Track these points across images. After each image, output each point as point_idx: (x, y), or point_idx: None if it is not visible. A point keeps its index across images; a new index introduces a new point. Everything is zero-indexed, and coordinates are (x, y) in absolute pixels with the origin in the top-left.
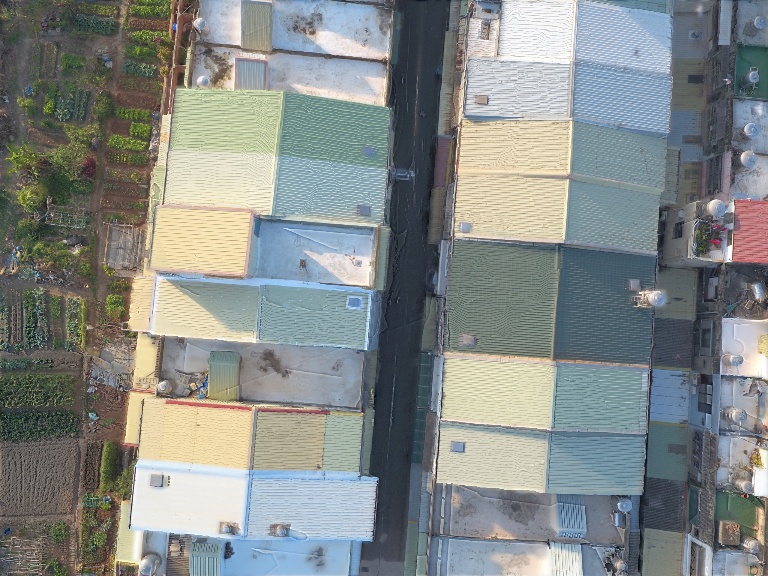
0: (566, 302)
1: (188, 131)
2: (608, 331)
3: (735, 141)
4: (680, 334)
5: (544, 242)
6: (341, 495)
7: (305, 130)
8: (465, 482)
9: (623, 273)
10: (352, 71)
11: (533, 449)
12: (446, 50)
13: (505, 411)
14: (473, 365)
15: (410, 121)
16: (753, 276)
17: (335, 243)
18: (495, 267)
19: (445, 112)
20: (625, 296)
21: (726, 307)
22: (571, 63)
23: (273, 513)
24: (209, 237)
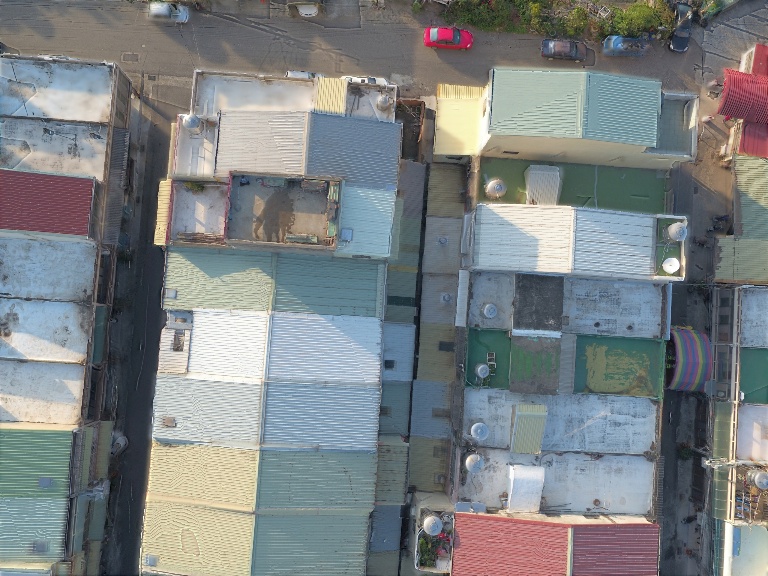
0: None
1: None
2: None
3: None
4: None
5: None
6: None
7: None
8: None
9: None
10: (51, 374)
11: None
12: None
13: None
14: None
15: (141, 398)
16: None
17: None
18: None
19: None
20: None
21: None
22: (262, 384)
23: None
24: None
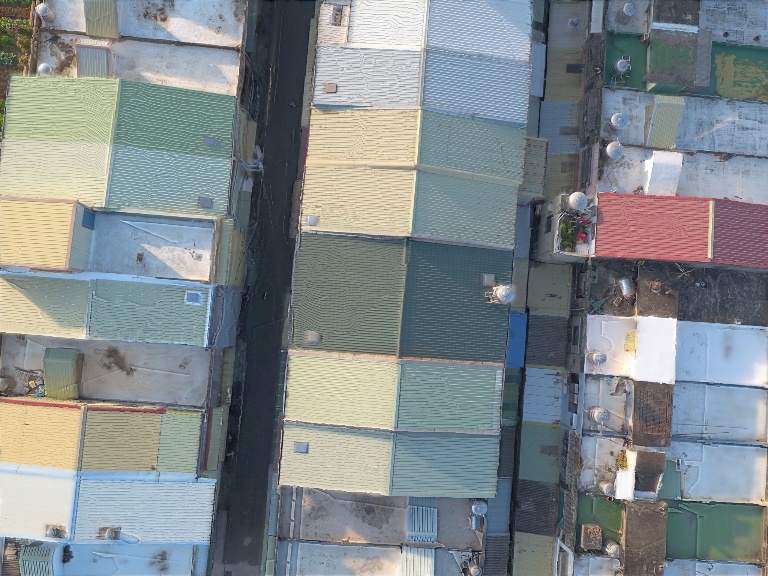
0: (414, 298)
1: (15, 119)
2: (457, 328)
3: (605, 132)
4: (554, 331)
5: (391, 235)
6: (177, 497)
7: (142, 119)
8: (308, 484)
9: (477, 268)
10: (205, 59)
11: (377, 450)
12: (311, 38)
13: (348, 410)
14: (316, 363)
15: (278, 111)
16: (622, 271)
17: (174, 236)
18: (349, 261)
19: (308, 102)
20: (479, 292)
21: (593, 303)
22: (422, 50)
23: (102, 516)
24: (32, 229)
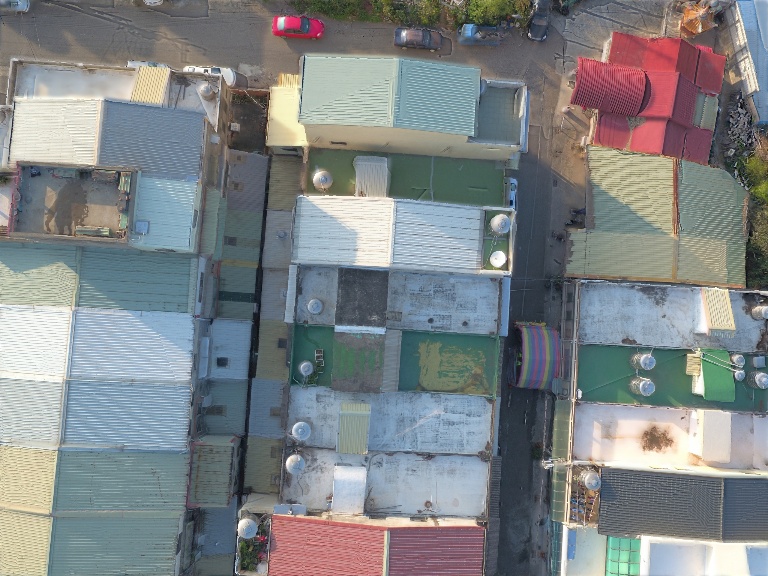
0: None
1: None
2: None
3: None
4: None
5: None
6: None
7: None
8: None
9: None
10: None
11: None
12: None
13: None
14: None
15: None
16: None
17: None
18: None
19: None
20: None
21: None
22: (64, 382)
23: None
24: None
